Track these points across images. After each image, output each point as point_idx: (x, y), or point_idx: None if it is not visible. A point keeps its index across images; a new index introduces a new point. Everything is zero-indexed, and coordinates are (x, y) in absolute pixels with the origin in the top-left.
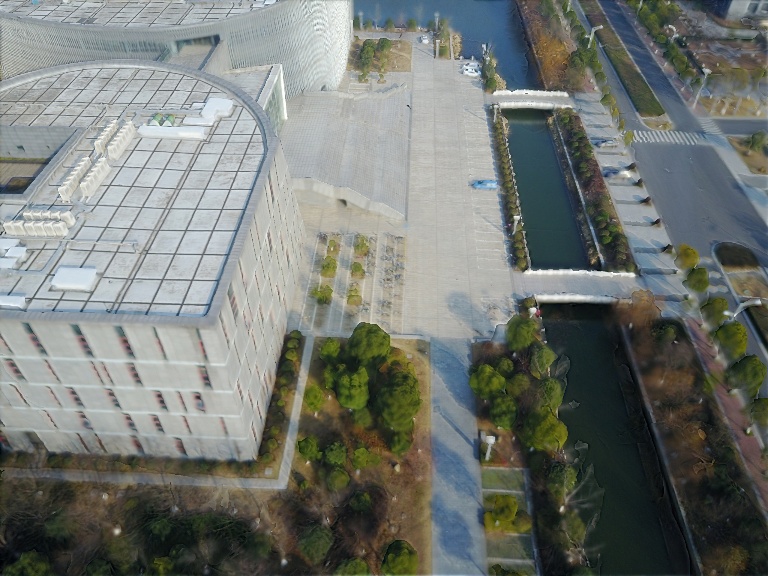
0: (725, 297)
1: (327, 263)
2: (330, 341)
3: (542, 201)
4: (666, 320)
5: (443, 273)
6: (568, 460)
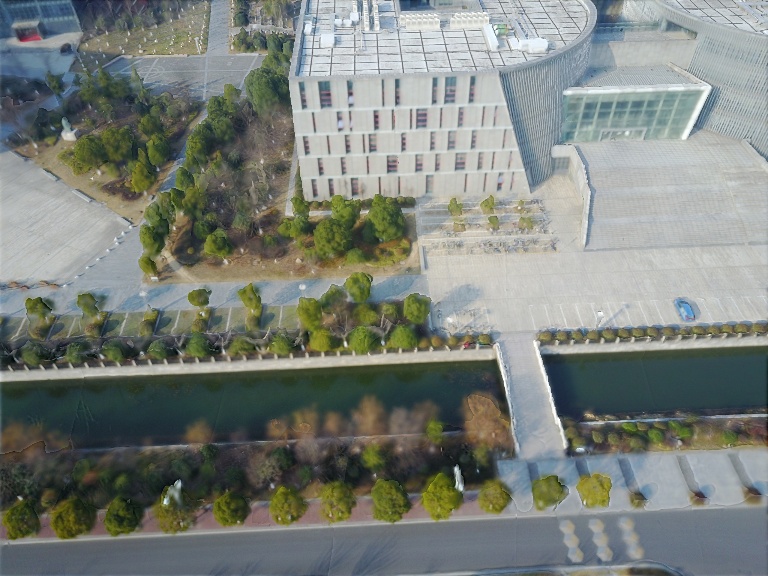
0: (556, 551)
1: (486, 199)
2: (380, 196)
3: (707, 382)
4: (492, 467)
5: (513, 280)
6: (321, 376)
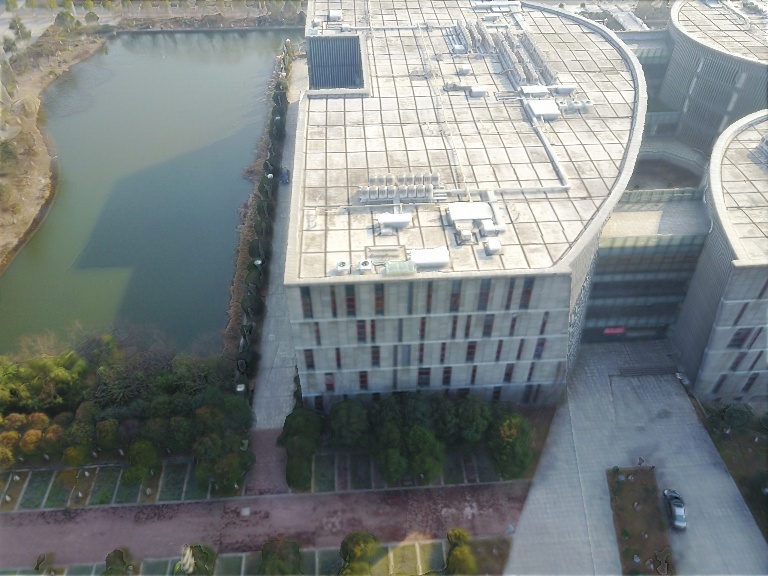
0: None
1: None
2: None
3: None
4: None
5: None
6: None
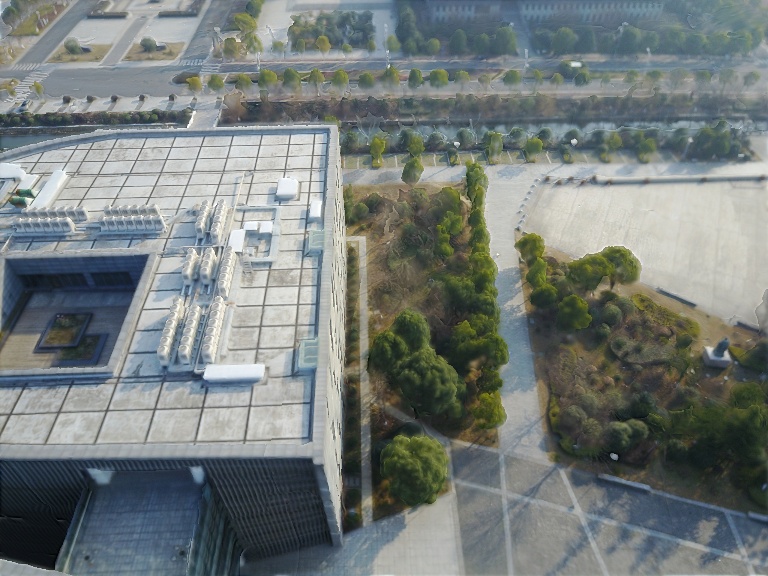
0: None
1: None
2: None
3: None
4: None
5: None
6: None
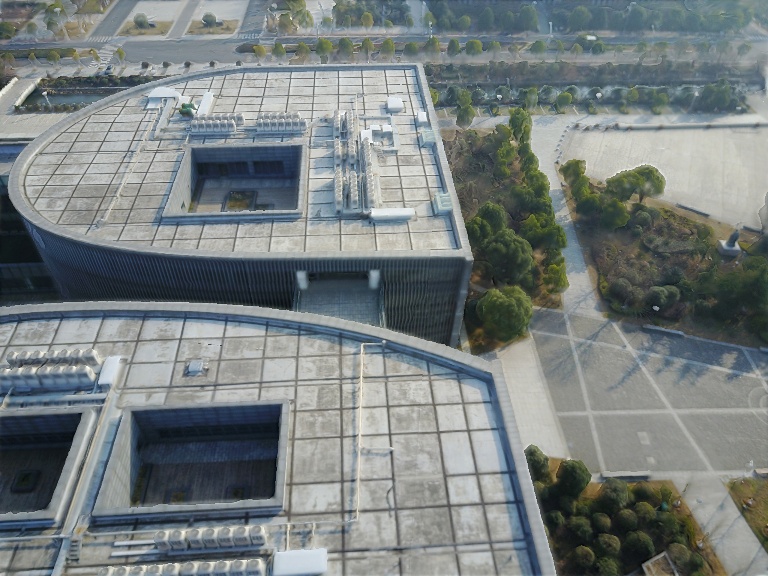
0: None
1: None
2: None
3: None
4: None
5: None
6: None
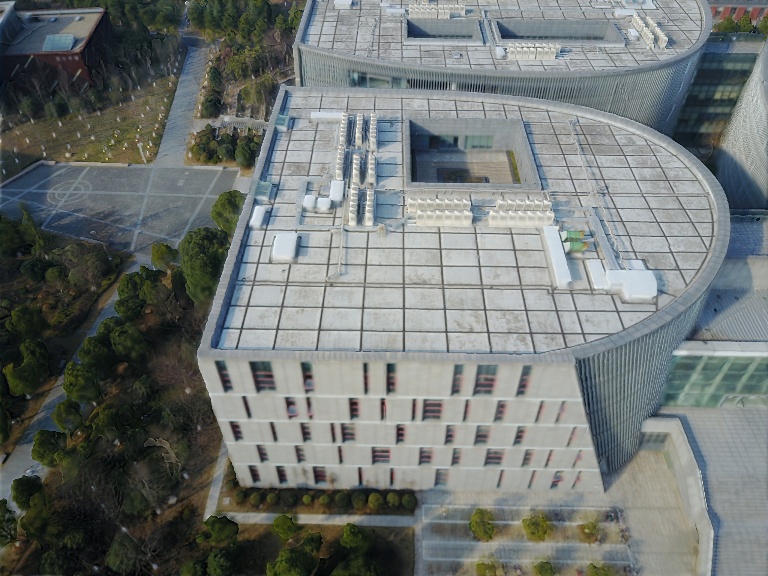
0: None
1: (534, 521)
2: (354, 531)
3: None
4: None
5: None
6: None
